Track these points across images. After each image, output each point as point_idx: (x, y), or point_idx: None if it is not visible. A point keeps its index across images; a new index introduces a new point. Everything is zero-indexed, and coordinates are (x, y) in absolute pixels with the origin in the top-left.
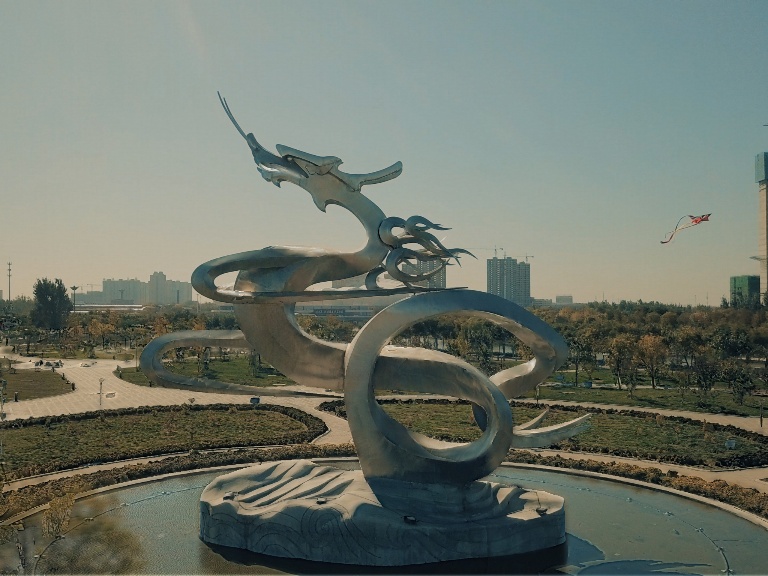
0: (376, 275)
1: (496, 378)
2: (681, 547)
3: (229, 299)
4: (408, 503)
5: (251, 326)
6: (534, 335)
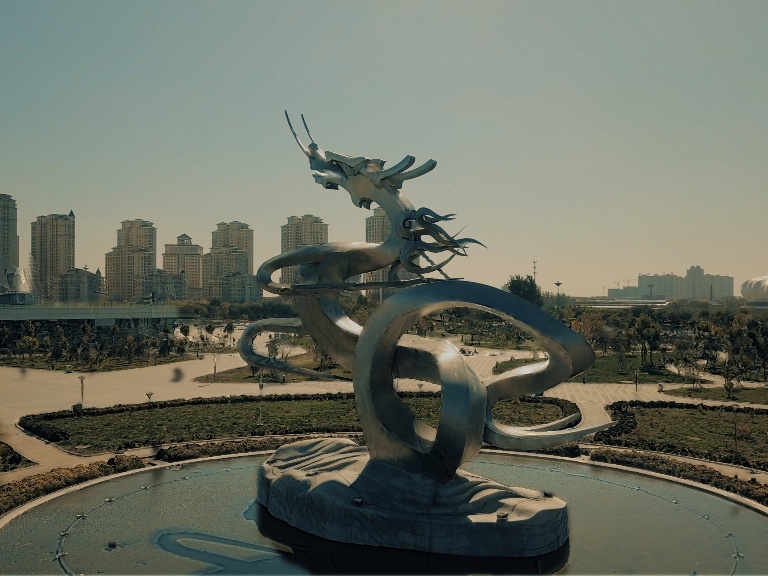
0: (398, 267)
1: (505, 374)
2: None
3: (276, 291)
4: (384, 488)
5: (304, 315)
6: (533, 329)
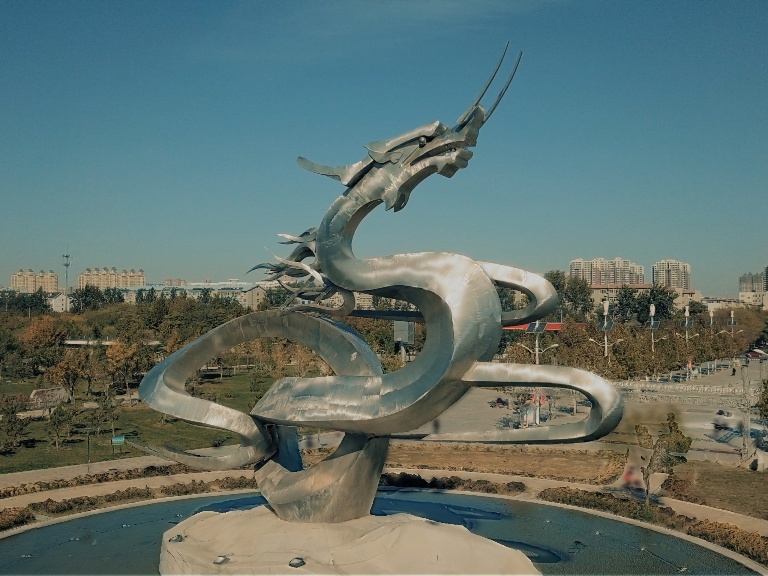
0: None
1: None
2: (137, 535)
3: (512, 322)
4: None
5: None
6: None
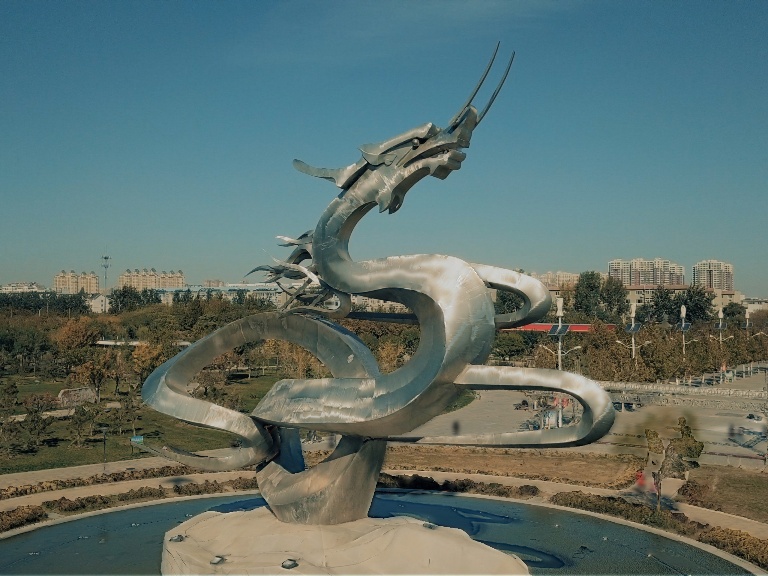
0: None
1: None
2: (145, 534)
3: None
4: None
5: None
6: None
